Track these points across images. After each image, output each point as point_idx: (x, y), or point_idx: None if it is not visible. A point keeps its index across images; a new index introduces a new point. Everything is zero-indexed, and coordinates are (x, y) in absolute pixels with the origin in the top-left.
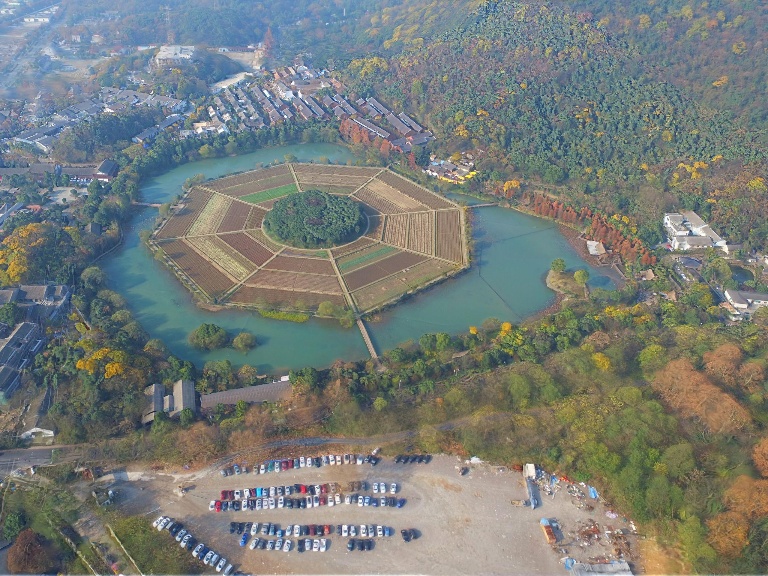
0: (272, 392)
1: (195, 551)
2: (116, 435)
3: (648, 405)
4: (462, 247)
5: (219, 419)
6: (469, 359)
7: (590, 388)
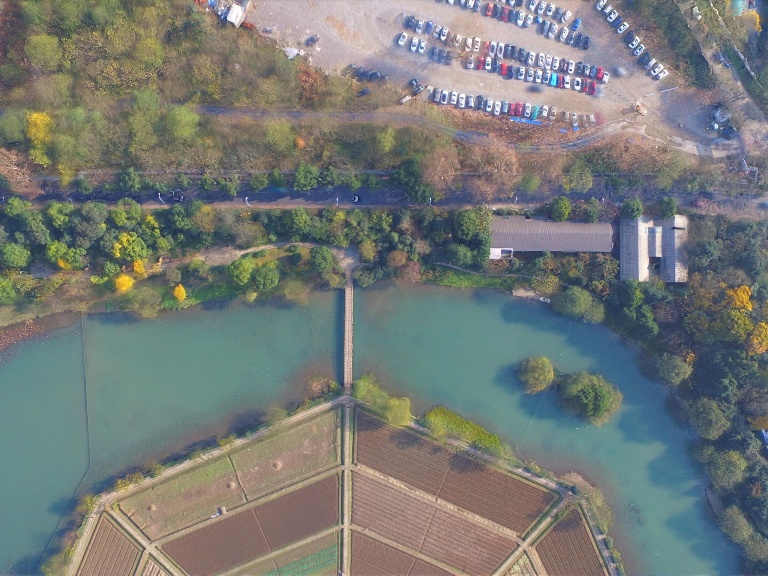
0: (519, 228)
1: (627, 26)
2: (721, 200)
3: (37, 10)
4: (78, 571)
5: (593, 196)
6: (221, 219)
7: (88, 85)
